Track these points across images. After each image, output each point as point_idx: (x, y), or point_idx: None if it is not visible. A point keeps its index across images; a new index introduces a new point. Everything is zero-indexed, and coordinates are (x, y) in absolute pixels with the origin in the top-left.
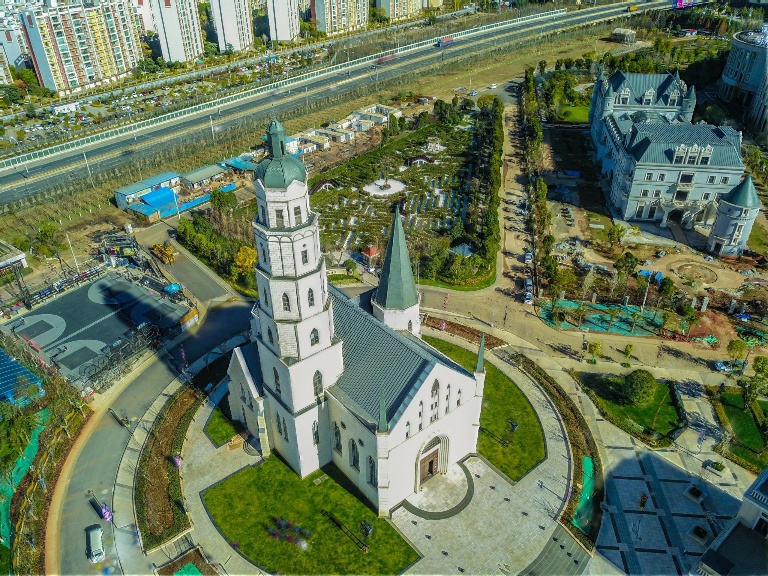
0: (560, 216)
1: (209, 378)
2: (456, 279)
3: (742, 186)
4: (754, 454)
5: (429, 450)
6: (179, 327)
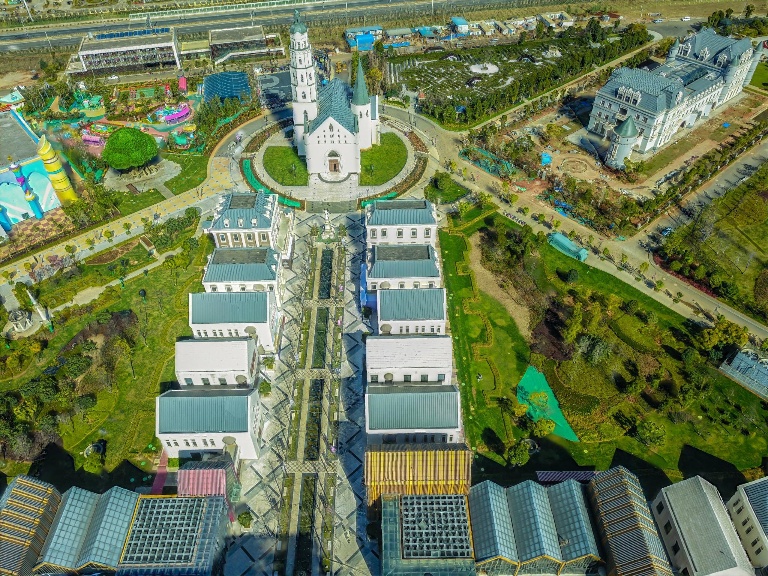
0: (556, 116)
1: None
2: (445, 122)
3: (624, 121)
4: (459, 220)
5: (333, 157)
6: None
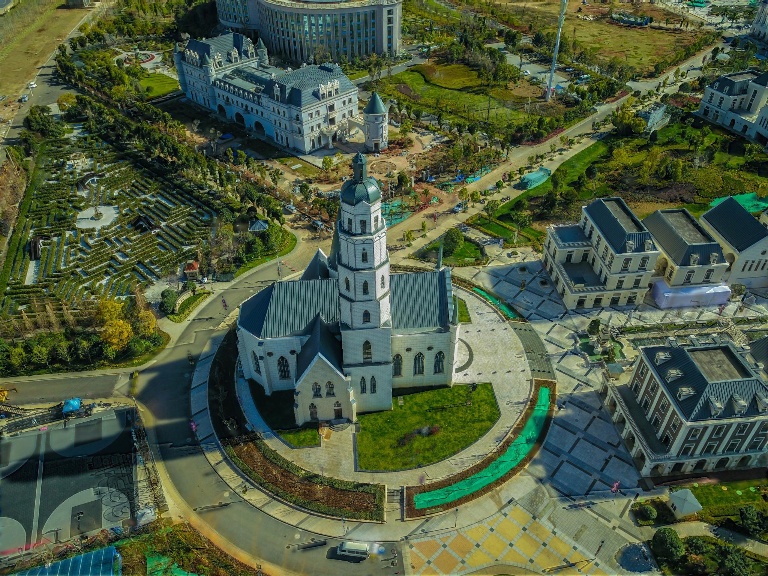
0: None
1: None
2: None
3: (375, 100)
4: None
5: None
6: (137, 422)
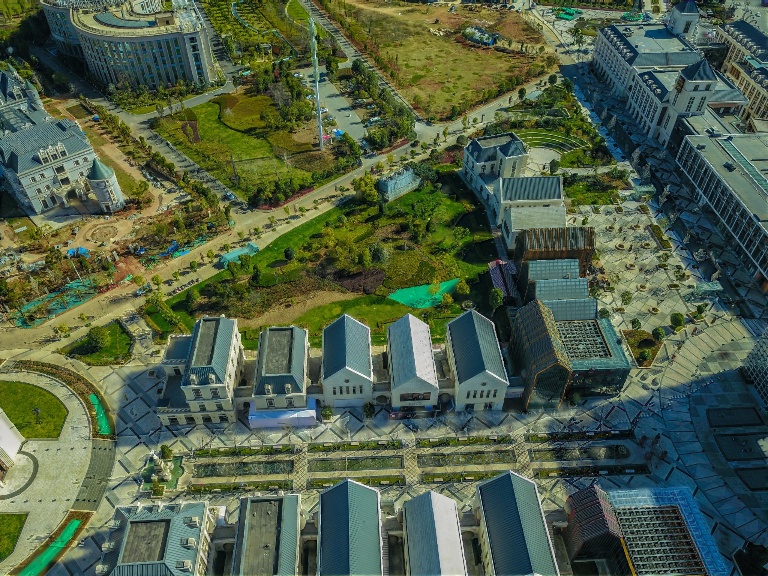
0: None
1: None
2: None
3: (95, 167)
4: (172, 333)
5: None
6: None
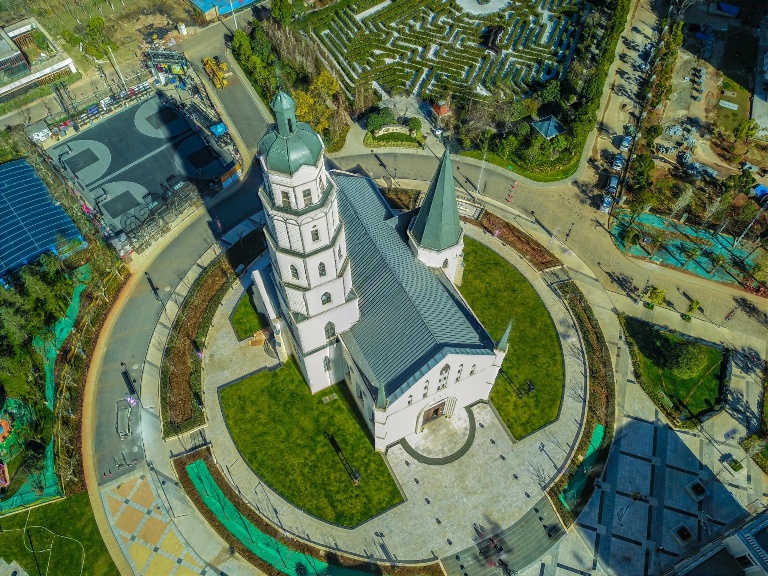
0: (688, 80)
1: (242, 255)
2: (530, 164)
3: None
4: None
5: (435, 404)
6: (220, 183)
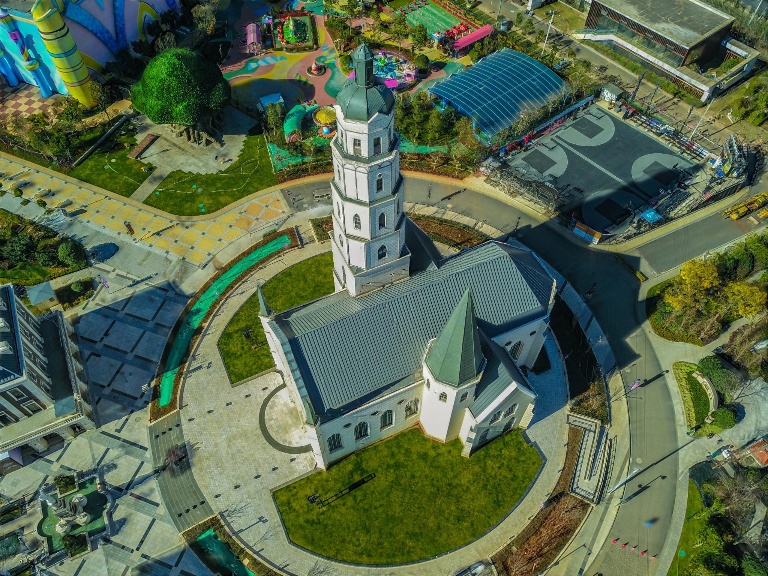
0: None
1: None
2: None
3: None
4: None
5: None
6: None
